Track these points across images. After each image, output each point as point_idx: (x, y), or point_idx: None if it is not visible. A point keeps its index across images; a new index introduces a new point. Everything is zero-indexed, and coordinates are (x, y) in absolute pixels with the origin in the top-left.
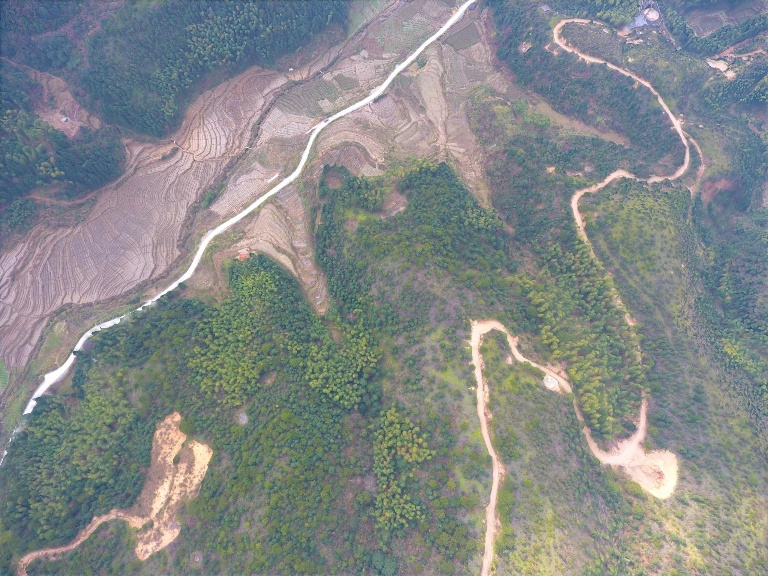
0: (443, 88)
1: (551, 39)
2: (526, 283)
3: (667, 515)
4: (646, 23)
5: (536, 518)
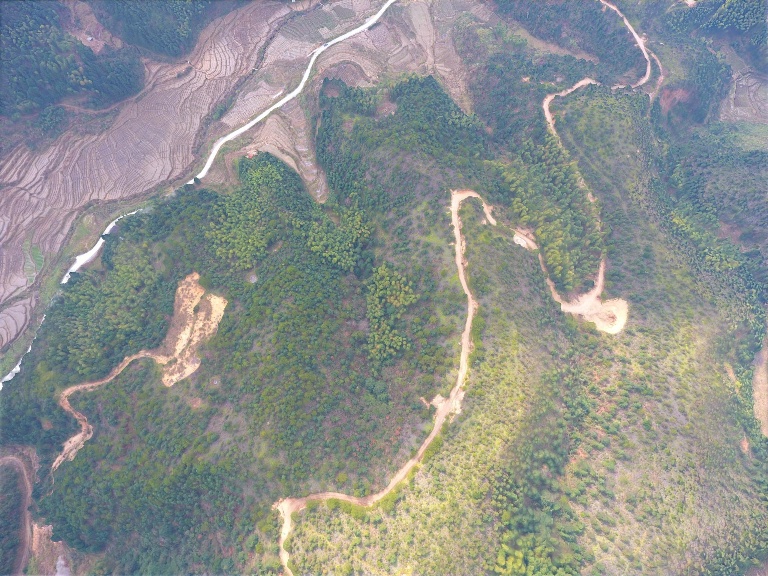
0: (431, 16)
1: None
2: (501, 166)
3: (617, 344)
4: None
5: (503, 335)
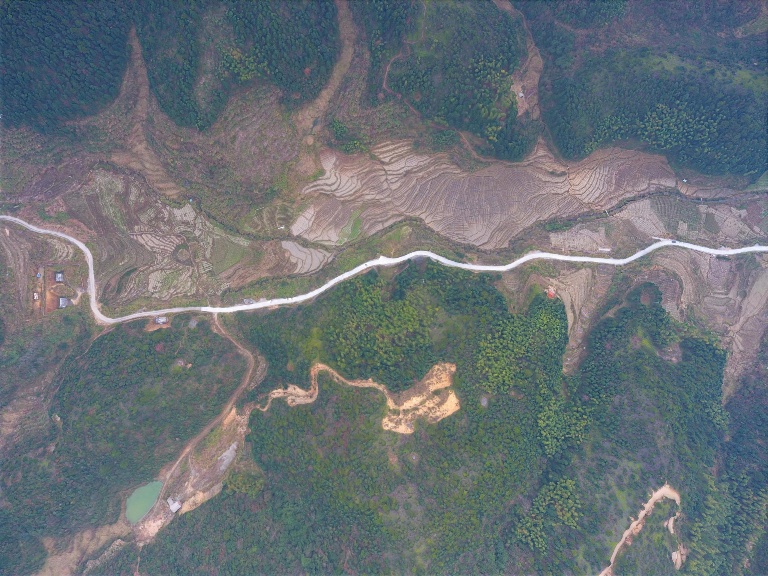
0: None
1: None
2: (711, 486)
3: None
4: None
5: None
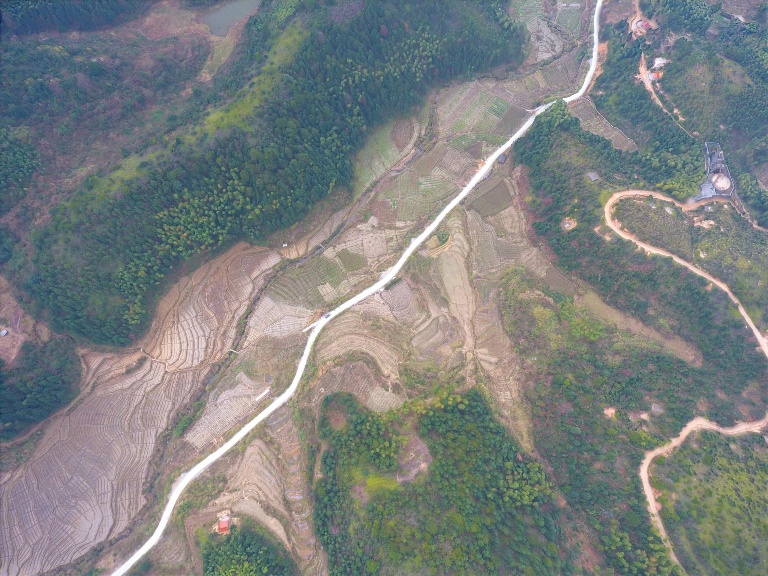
0: (469, 273)
1: (602, 221)
2: None
3: None
4: (715, 194)
5: None
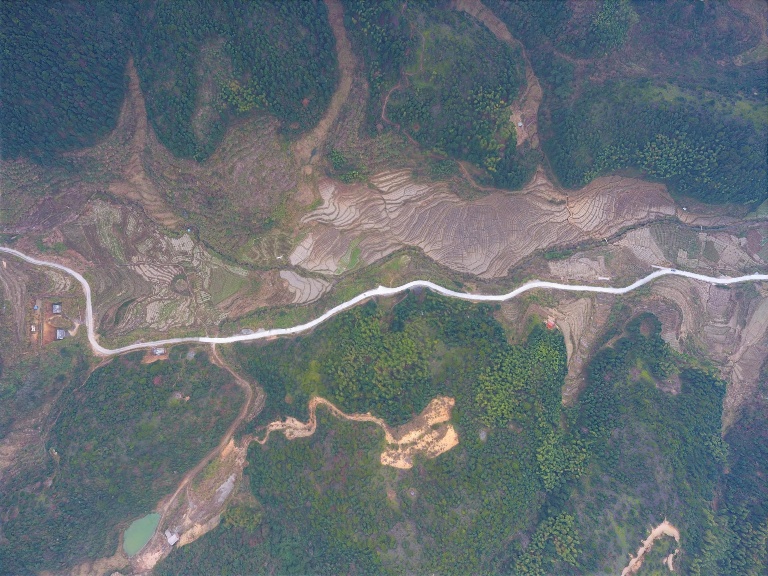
0: None
1: None
2: (711, 521)
3: None
4: None
5: None
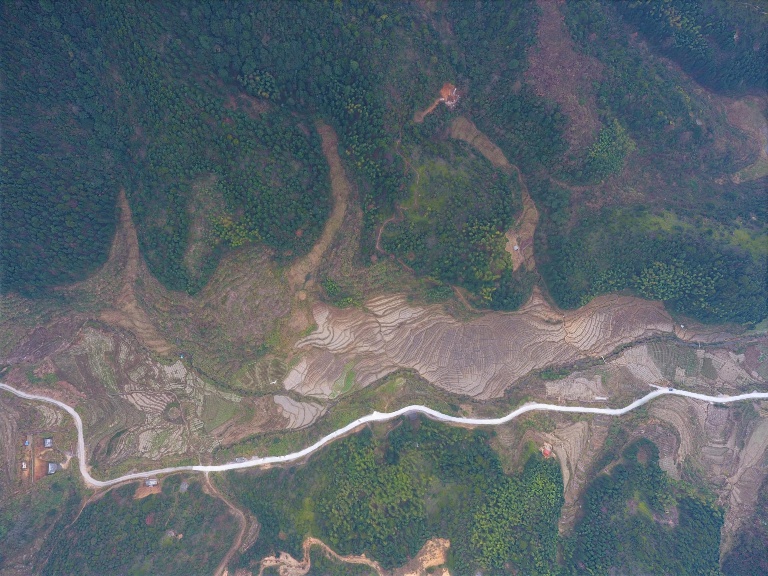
0: None
1: None
2: None
3: None
4: None
5: None
